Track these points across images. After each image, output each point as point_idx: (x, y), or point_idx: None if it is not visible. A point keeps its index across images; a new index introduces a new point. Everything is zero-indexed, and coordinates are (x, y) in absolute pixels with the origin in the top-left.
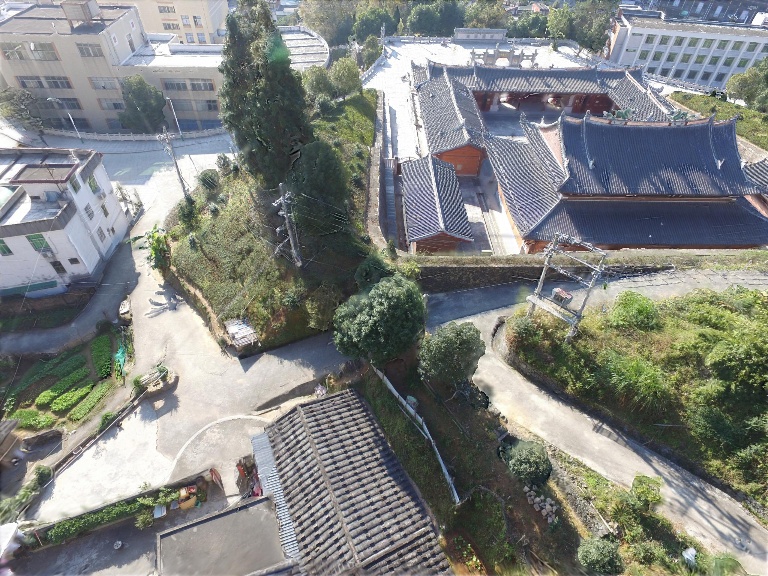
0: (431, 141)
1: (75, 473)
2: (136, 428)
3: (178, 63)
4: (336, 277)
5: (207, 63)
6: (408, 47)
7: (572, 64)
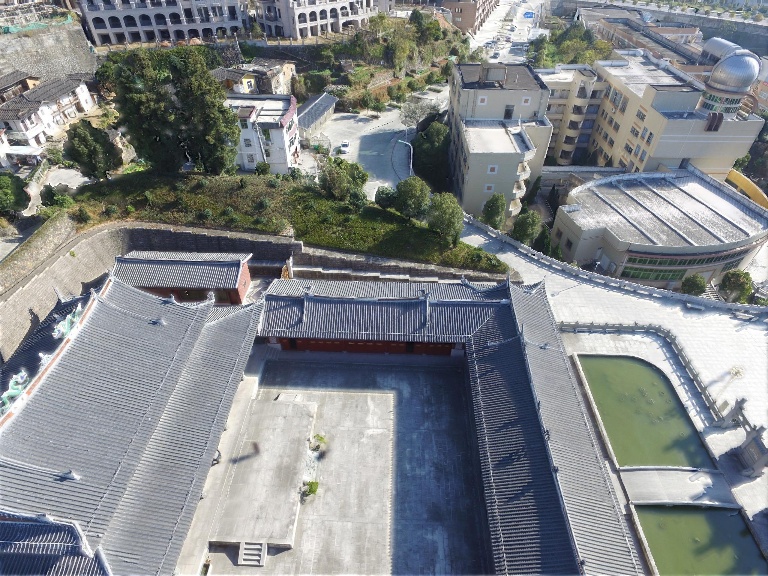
0: (302, 281)
1: (71, 172)
2: (80, 180)
3: (489, 138)
4: (74, 193)
5: (495, 150)
6: None
7: None
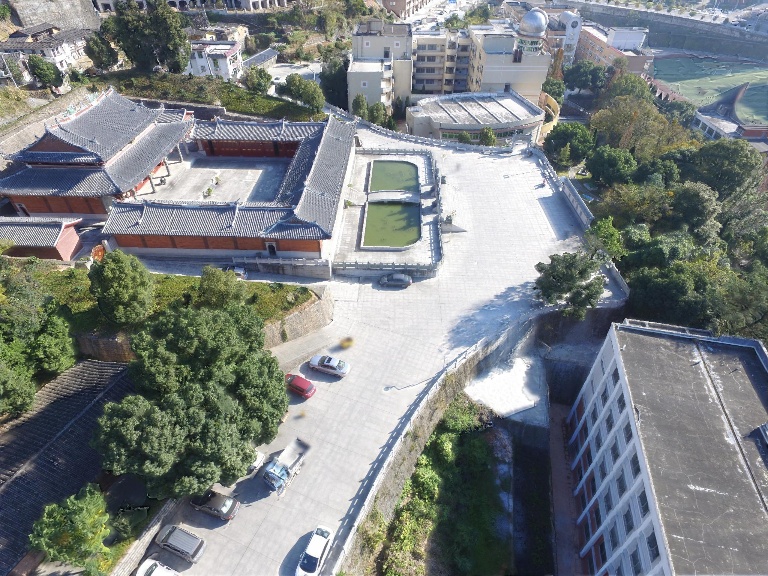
0: None
1: None
2: None
3: (368, 67)
4: None
5: None
6: (523, 164)
7: (511, 279)
